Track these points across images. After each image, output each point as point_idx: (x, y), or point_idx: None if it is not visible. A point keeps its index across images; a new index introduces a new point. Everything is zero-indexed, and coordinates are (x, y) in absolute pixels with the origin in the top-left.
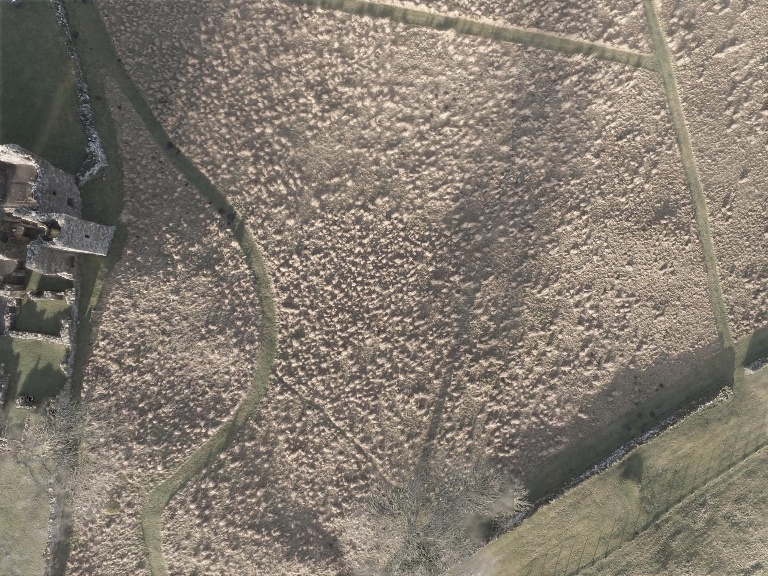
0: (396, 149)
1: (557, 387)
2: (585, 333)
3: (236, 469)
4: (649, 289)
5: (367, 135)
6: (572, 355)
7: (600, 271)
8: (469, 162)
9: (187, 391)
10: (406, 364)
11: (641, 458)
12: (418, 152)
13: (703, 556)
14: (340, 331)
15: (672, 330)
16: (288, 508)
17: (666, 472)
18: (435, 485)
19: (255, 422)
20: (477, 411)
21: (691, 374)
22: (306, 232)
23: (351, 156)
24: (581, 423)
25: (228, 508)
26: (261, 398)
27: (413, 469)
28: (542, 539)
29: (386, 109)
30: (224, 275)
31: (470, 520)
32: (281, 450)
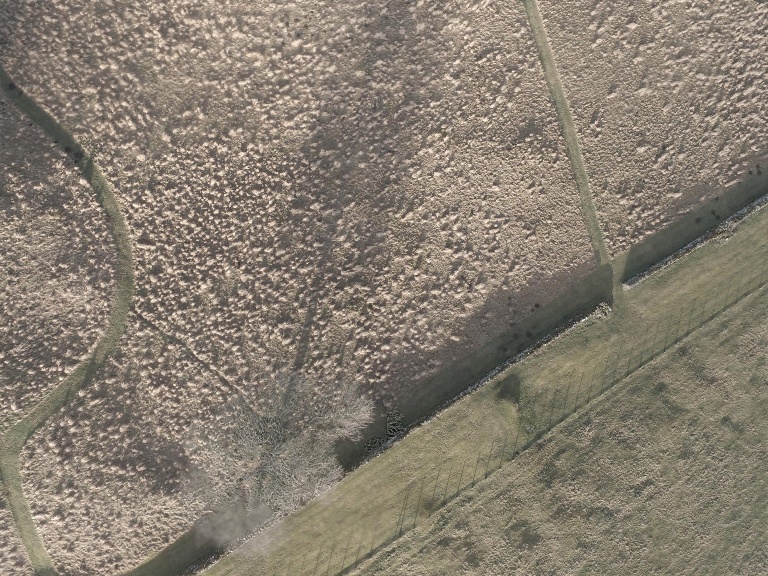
0: (248, 80)
1: (428, 311)
2: (454, 256)
3: (97, 407)
4: (518, 209)
5: (218, 67)
6: (442, 279)
7: (466, 193)
8: (324, 89)
9: (41, 331)
10: (269, 295)
11: (518, 378)
12: (271, 82)
13: (589, 474)
14: (199, 265)
15: (545, 249)
16: (153, 443)
17: (546, 392)
18: (304, 414)
19: (114, 359)
20: (345, 339)
21: (568, 293)
22: (158, 167)
23: (202, 89)
24: (454, 346)
25: (90, 446)
26: (120, 335)
27: (280, 399)
28: (418, 463)
29: (236, 40)
30: (74, 214)
31: (342, 447)
32: (144, 386)
